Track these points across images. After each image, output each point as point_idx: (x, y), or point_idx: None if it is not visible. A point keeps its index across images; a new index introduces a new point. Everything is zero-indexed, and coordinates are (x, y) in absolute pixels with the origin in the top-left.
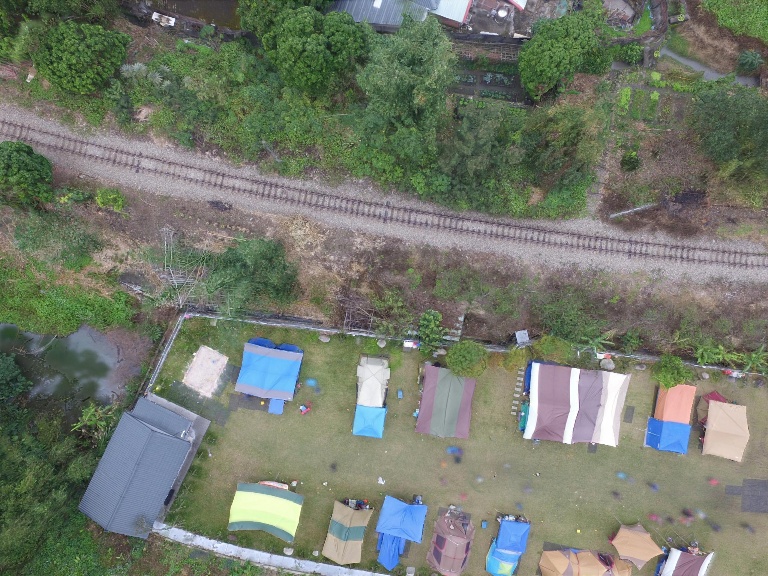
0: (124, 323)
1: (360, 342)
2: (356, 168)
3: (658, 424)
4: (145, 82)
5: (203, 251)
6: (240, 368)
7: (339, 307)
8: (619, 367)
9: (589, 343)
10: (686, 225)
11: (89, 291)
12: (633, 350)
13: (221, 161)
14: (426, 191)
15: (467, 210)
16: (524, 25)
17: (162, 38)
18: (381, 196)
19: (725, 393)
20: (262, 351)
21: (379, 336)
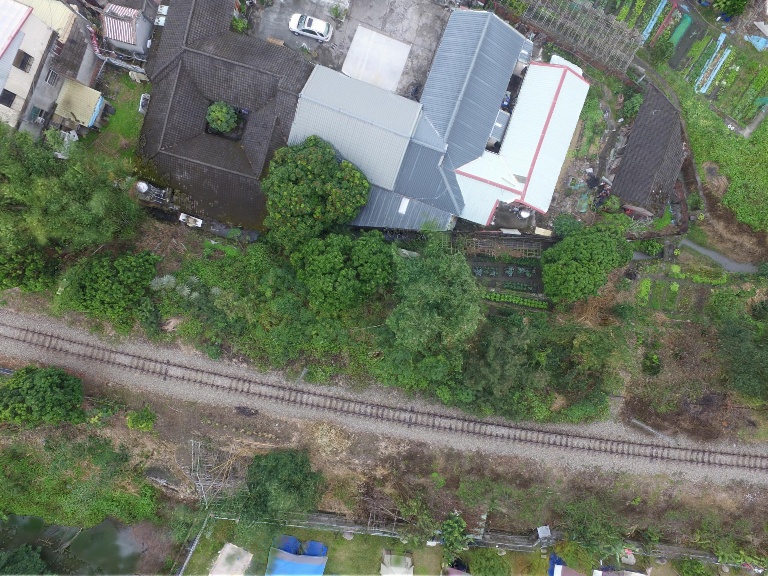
0: (149, 516)
1: (383, 538)
2: (381, 376)
3: None
4: (174, 296)
5: (229, 455)
6: (264, 564)
7: (362, 500)
8: (640, 561)
9: (612, 550)
10: (707, 430)
11: (115, 489)
12: None
13: (248, 367)
14: (450, 400)
15: (490, 414)
16: (545, 218)
17: (189, 239)
18: (406, 401)
19: None
20: (287, 557)
21: (403, 537)
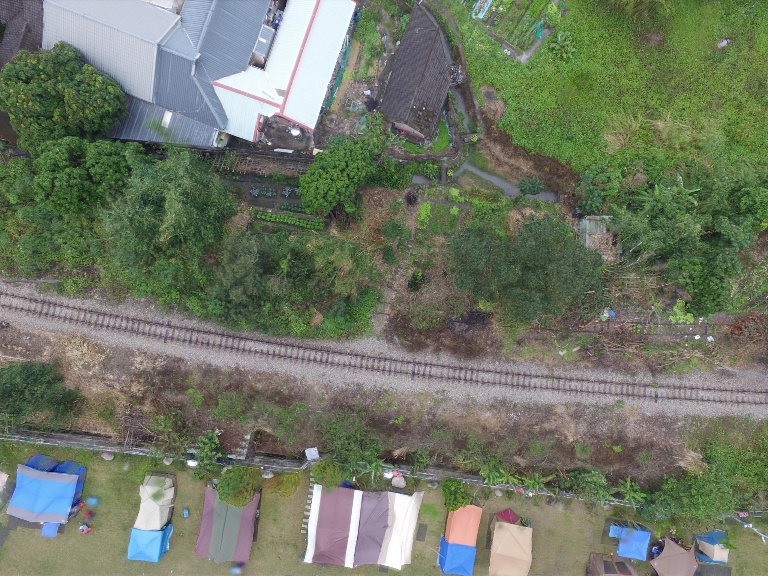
0: None
1: (146, 459)
2: (135, 288)
3: (445, 546)
4: None
5: None
6: None
7: None
8: (412, 484)
9: (367, 467)
10: (468, 347)
11: None
12: (429, 466)
13: None
14: (204, 312)
15: (250, 330)
16: (324, 140)
17: None
18: (163, 315)
19: (519, 511)
20: (33, 474)
21: (160, 456)
